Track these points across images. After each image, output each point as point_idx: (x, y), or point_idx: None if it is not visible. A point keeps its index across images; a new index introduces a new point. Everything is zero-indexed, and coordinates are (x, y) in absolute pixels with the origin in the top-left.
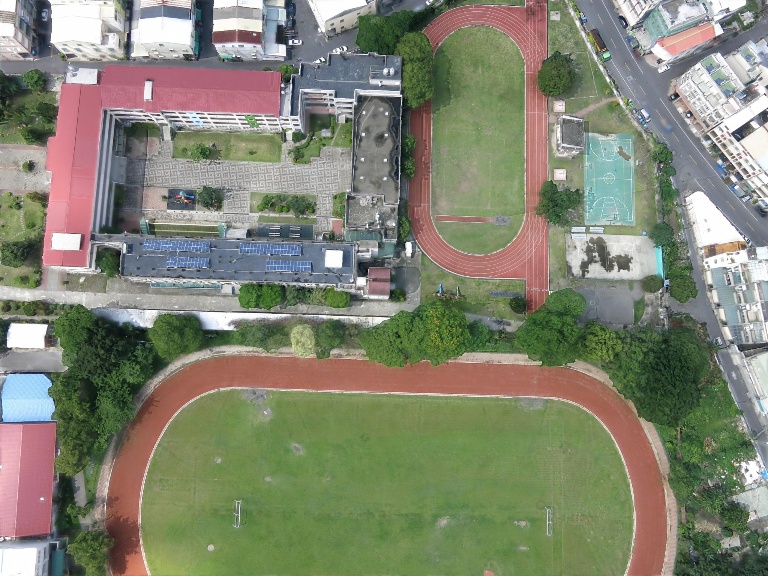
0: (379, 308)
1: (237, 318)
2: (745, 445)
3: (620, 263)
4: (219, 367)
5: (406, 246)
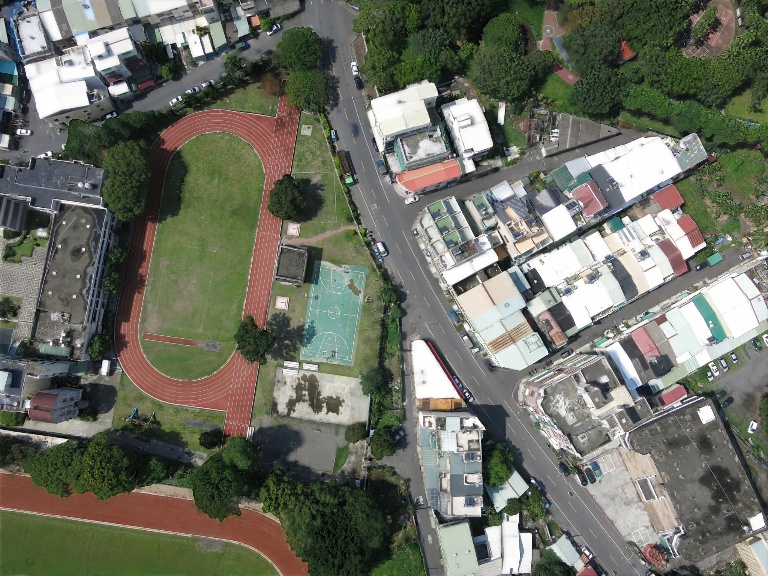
0: (67, 425)
1: None
2: None
3: (330, 405)
4: None
5: (102, 364)
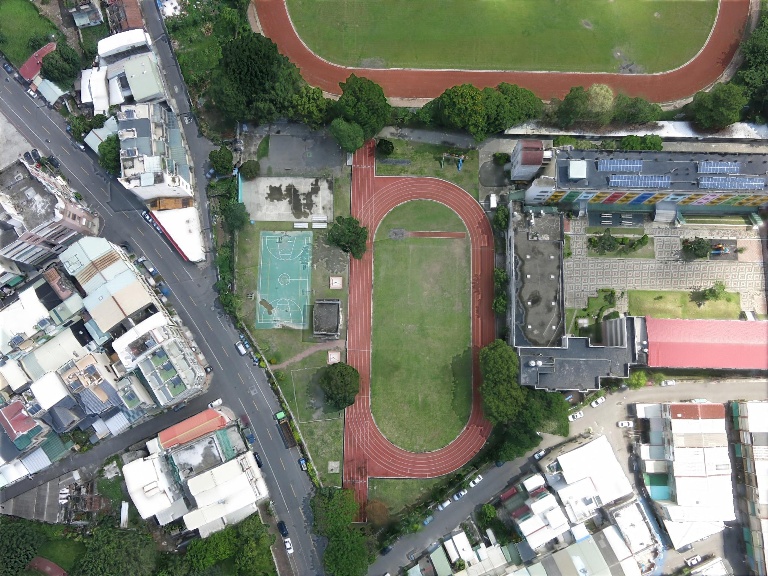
0: None
1: (657, 132)
2: (174, 28)
3: (279, 193)
4: (666, 92)
5: None
